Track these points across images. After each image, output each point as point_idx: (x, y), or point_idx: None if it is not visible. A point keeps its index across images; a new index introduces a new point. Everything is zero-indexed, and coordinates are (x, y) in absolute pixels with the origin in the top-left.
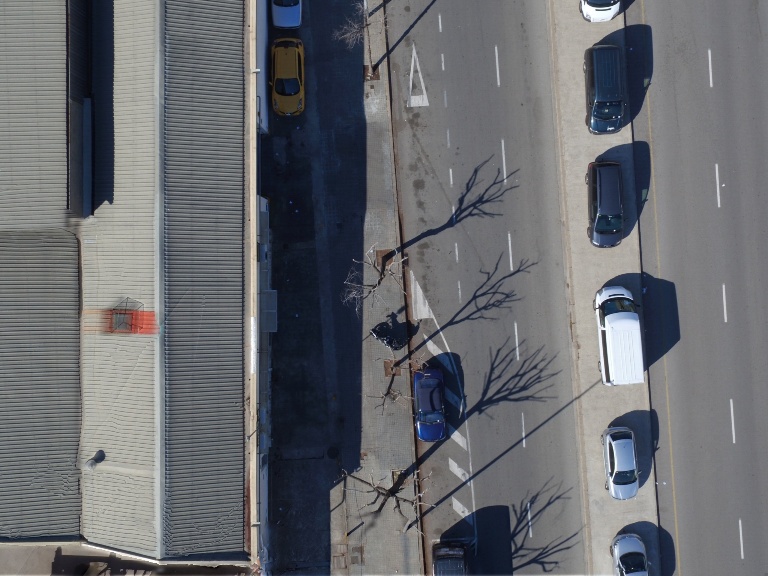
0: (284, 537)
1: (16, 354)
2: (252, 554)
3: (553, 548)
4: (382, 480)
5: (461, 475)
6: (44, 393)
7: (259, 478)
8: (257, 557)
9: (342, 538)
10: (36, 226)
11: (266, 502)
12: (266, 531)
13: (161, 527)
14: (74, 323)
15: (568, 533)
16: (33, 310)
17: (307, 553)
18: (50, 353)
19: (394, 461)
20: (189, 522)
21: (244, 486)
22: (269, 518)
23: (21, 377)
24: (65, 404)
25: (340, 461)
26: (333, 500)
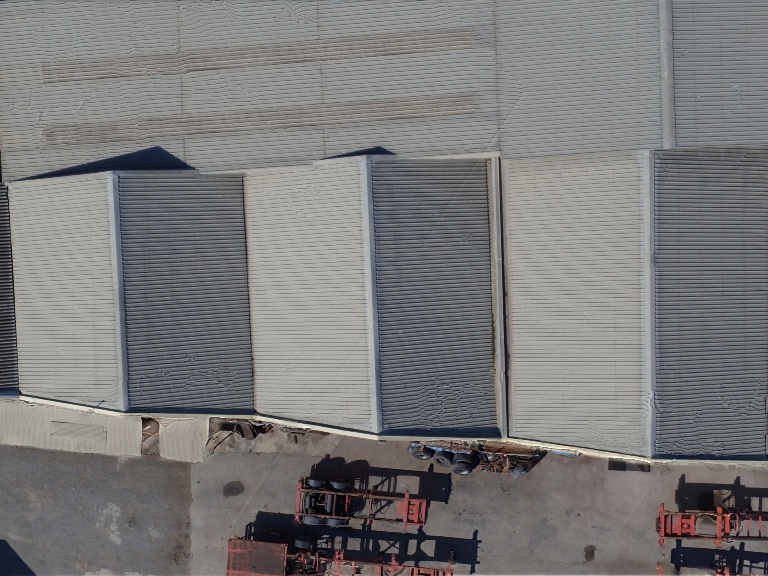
0: None
1: (711, 273)
2: None
3: None
4: None
5: None
6: (732, 312)
7: None
8: None
9: None
10: (753, 142)
11: None
12: None
13: None
14: (764, 242)
15: None
16: (725, 229)
17: None
18: (738, 272)
19: None
20: None
21: None
22: None
23: (714, 296)
24: (750, 324)
25: None
26: None
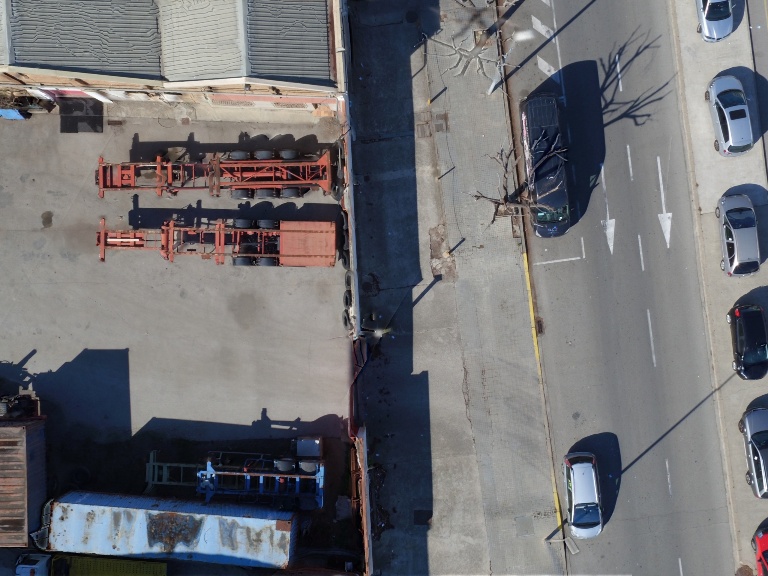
0: (366, 106)
1: None
2: (339, 81)
3: (645, 100)
4: (464, 41)
5: (545, 32)
6: None
7: (341, 12)
8: (344, 88)
9: (425, 105)
10: None
11: (349, 40)
12: (350, 74)
13: (246, 42)
14: None
15: (660, 83)
16: None
17: (390, 123)
18: None
19: (475, 21)
20: (274, 33)
21: (327, 12)
22: (352, 62)
23: None
24: None
25: (419, 25)
26: (414, 66)
